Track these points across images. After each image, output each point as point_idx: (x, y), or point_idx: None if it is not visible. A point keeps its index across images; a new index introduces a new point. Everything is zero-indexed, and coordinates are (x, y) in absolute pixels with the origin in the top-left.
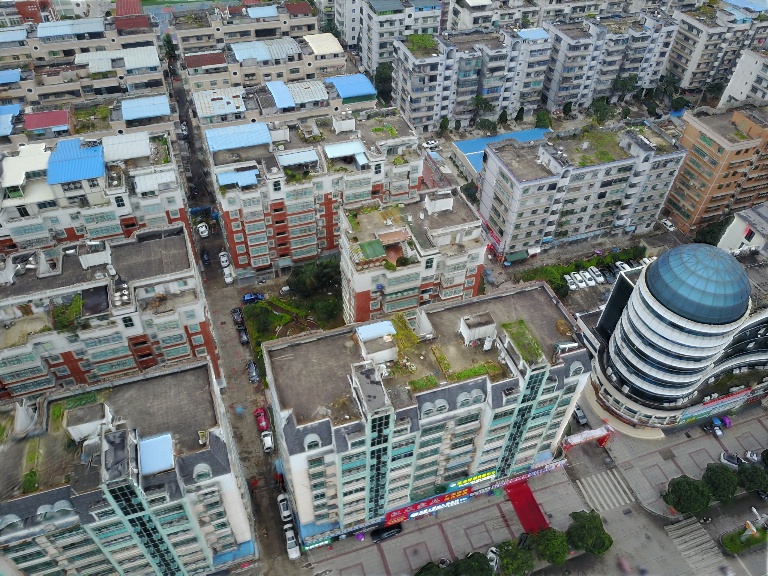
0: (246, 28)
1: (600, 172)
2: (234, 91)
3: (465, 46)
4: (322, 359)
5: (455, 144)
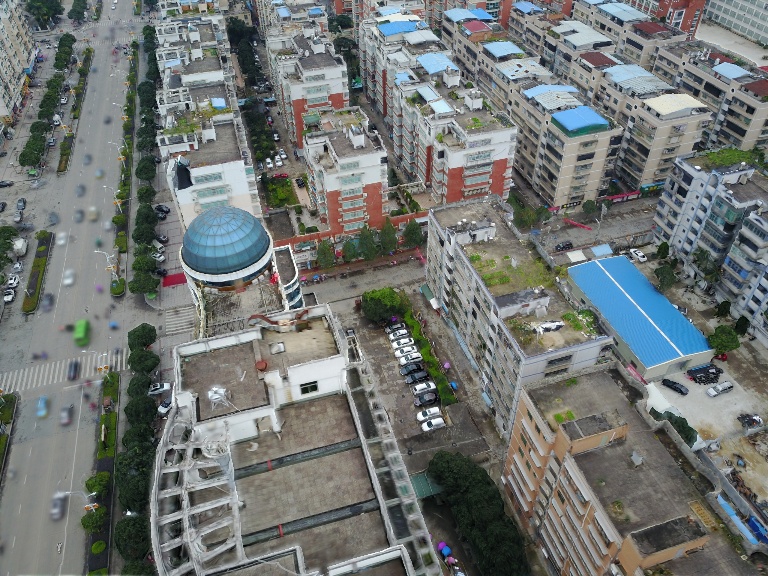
0: (703, 76)
1: (473, 278)
2: (538, 71)
3: (758, 196)
4: (213, 97)
5: (620, 256)
